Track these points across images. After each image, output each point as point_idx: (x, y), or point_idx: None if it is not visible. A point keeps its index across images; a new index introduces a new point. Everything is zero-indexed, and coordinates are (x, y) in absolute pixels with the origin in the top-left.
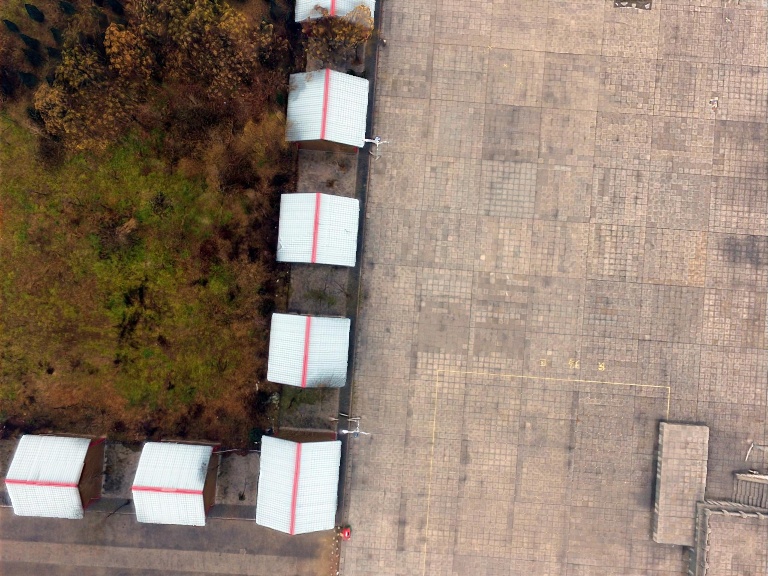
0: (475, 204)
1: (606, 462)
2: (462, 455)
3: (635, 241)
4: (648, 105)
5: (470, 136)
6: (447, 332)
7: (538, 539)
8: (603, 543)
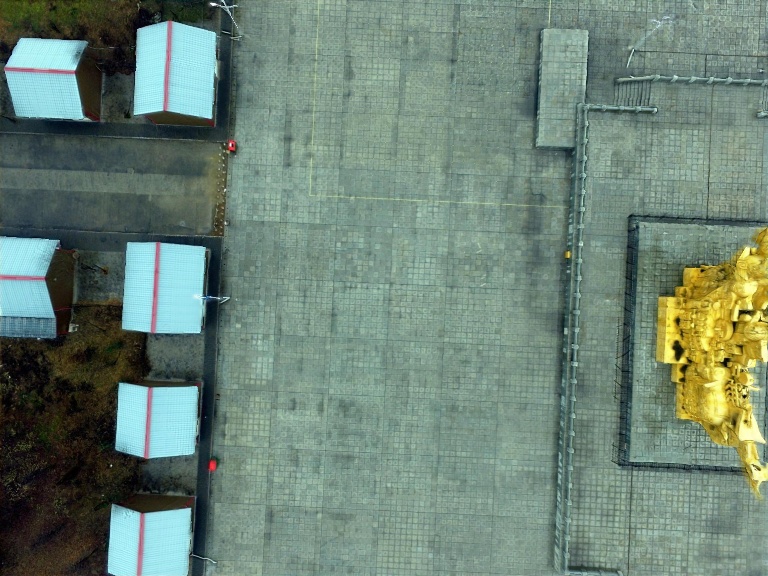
0: None
1: (489, 74)
2: (345, 71)
3: None
4: None
5: None
6: None
7: (422, 151)
8: (487, 153)
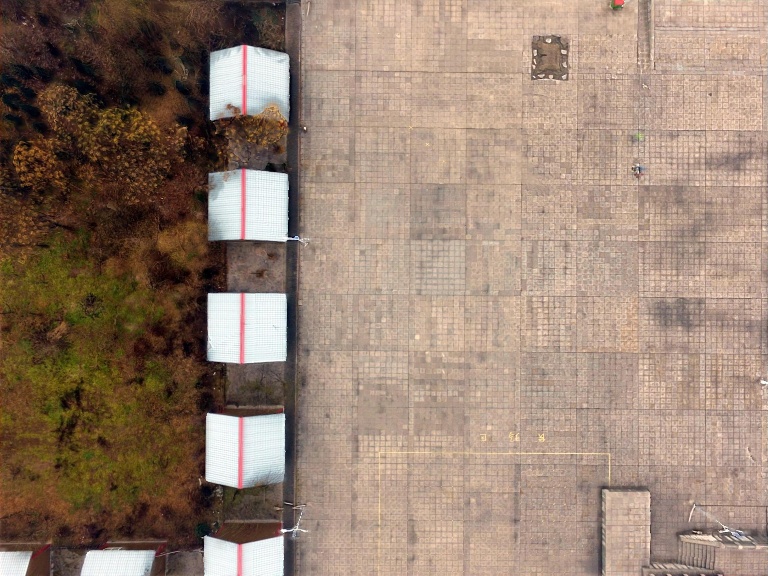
0: (406, 284)
1: (552, 532)
2: (409, 535)
3: (567, 311)
4: (571, 175)
5: (397, 217)
6: (386, 414)
7: None
8: None
